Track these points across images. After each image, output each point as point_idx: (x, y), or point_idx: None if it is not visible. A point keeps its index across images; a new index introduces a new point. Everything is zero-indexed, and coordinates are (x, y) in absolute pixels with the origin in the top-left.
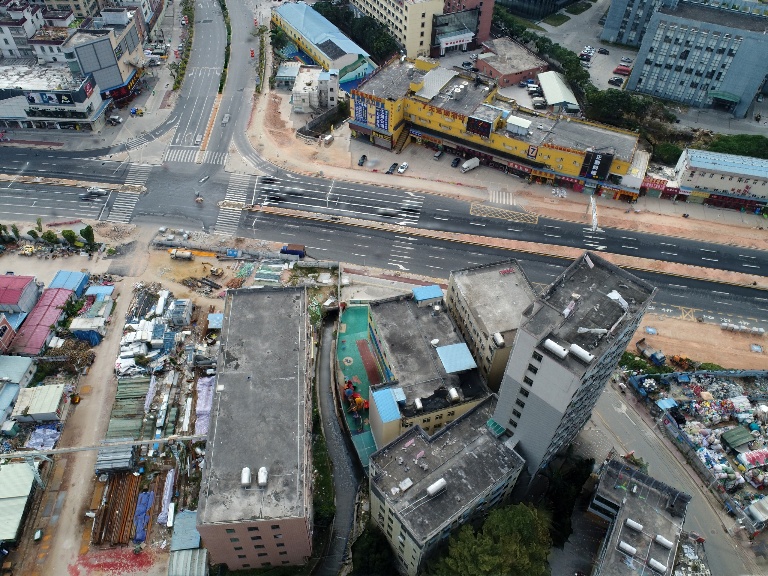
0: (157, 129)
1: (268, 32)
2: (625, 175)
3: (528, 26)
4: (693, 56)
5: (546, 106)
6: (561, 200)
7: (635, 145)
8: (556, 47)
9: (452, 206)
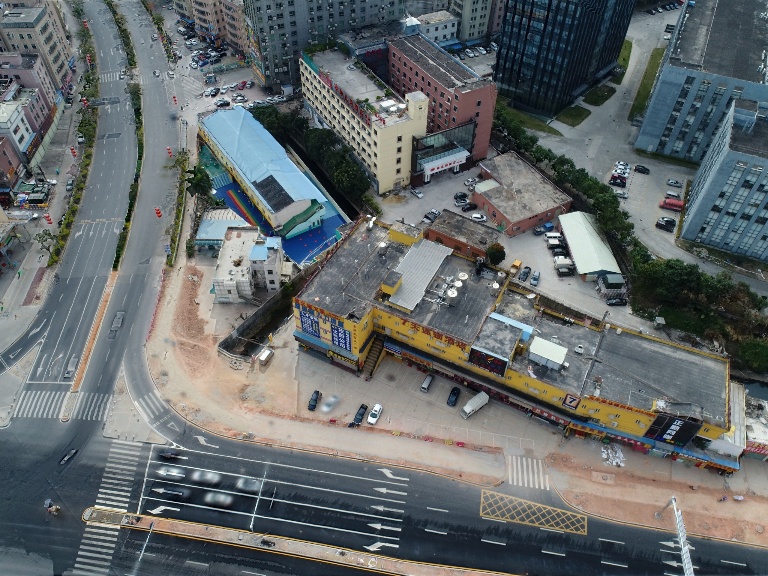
0: (13, 347)
1: (193, 152)
2: (716, 439)
3: (538, 128)
4: None
5: (574, 271)
6: (617, 473)
7: (726, 384)
8: (582, 176)
9: (452, 499)
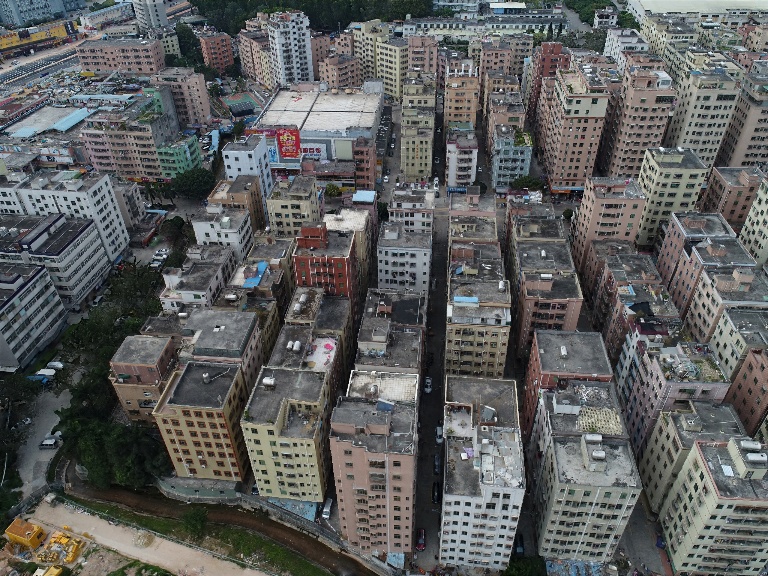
0: None
1: None
2: (78, 28)
3: None
4: (34, 1)
5: None
6: None
7: None
8: None
9: None
